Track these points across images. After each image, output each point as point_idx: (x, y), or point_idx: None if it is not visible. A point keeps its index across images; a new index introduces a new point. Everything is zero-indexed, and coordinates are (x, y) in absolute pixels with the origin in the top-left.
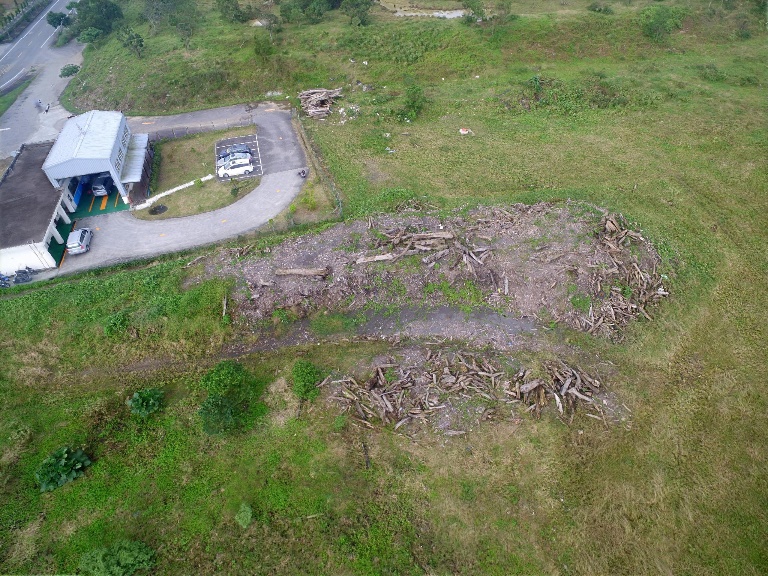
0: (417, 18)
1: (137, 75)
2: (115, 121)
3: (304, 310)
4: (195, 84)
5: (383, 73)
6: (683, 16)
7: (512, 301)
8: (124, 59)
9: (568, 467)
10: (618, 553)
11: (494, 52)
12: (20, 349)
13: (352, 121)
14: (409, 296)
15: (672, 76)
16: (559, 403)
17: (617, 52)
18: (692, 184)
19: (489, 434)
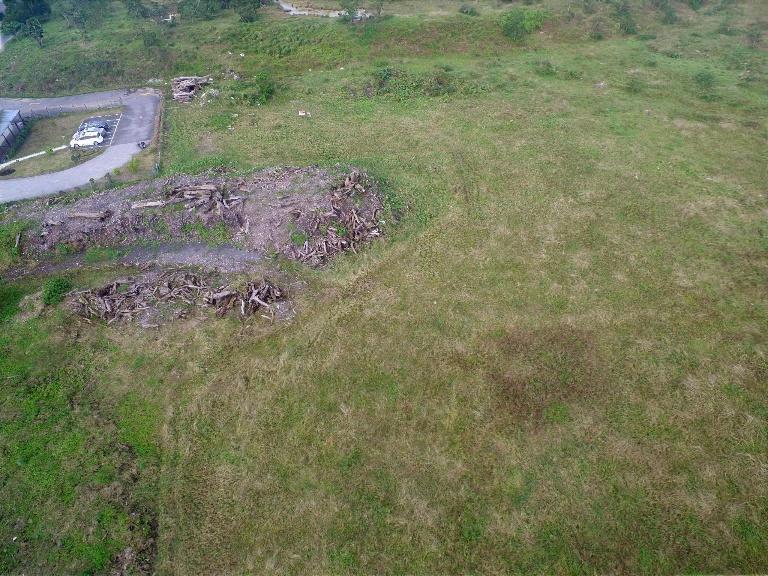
0: (303, 16)
1: (34, 62)
2: None
3: (84, 245)
4: (82, 71)
5: (256, 64)
6: (544, 18)
7: (250, 238)
8: (28, 48)
9: (223, 348)
10: (223, 399)
11: (363, 47)
12: None
13: (209, 104)
14: (171, 234)
15: (510, 70)
16: (242, 307)
17: (475, 49)
18: (465, 156)
19: (177, 327)
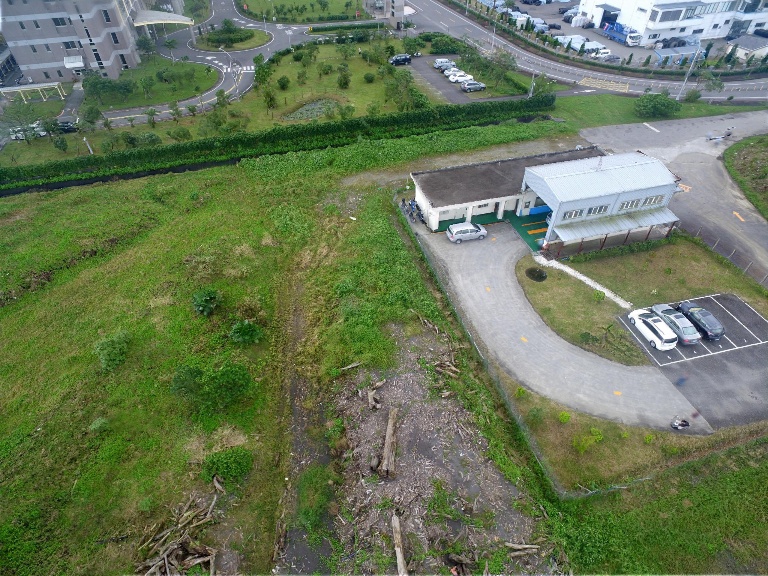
0: None
1: None
2: (649, 182)
3: None
4: None
5: None
6: None
7: None
8: None
9: None
10: None
11: None
12: (333, 244)
13: None
14: None
15: None
16: None
17: None
18: None
19: None
